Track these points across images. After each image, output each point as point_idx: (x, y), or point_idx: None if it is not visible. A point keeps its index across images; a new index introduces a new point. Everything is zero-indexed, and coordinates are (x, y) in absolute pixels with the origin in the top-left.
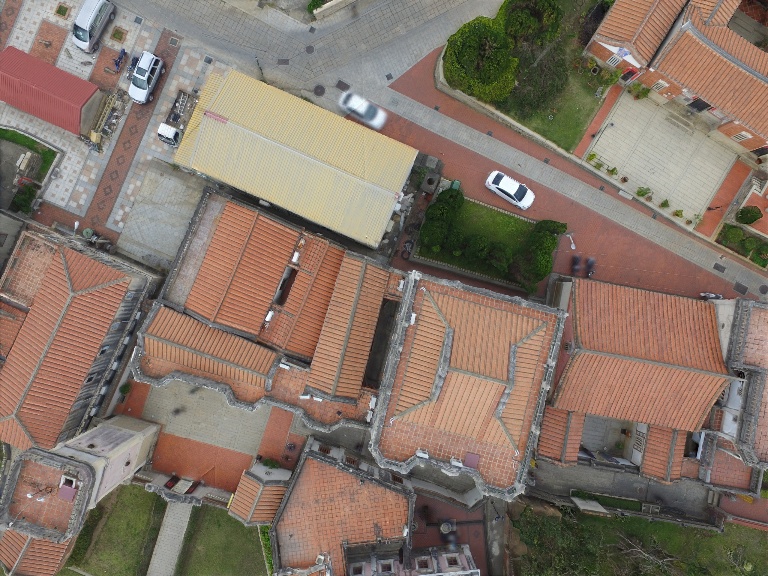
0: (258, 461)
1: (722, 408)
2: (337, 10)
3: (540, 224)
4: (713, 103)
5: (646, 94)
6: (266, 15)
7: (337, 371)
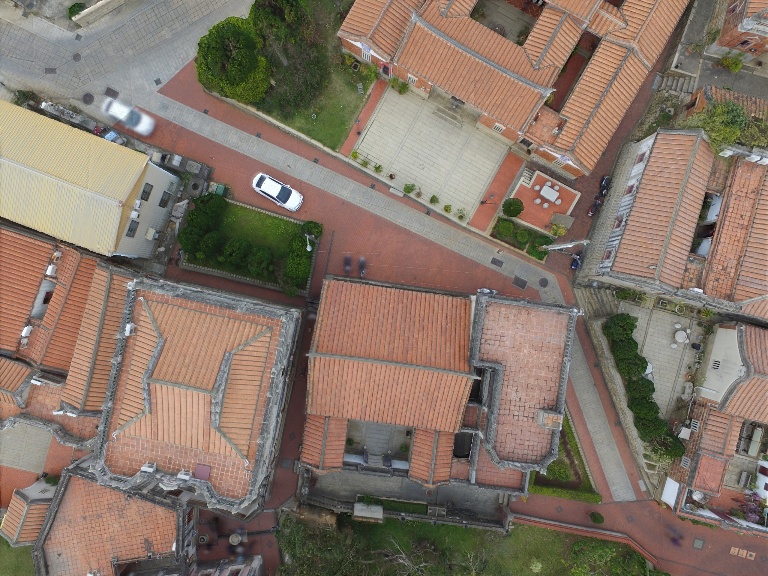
0: (42, 479)
1: (482, 407)
2: (101, 16)
3: (302, 226)
4: (457, 95)
5: (405, 89)
6: (31, 24)
7: (86, 385)
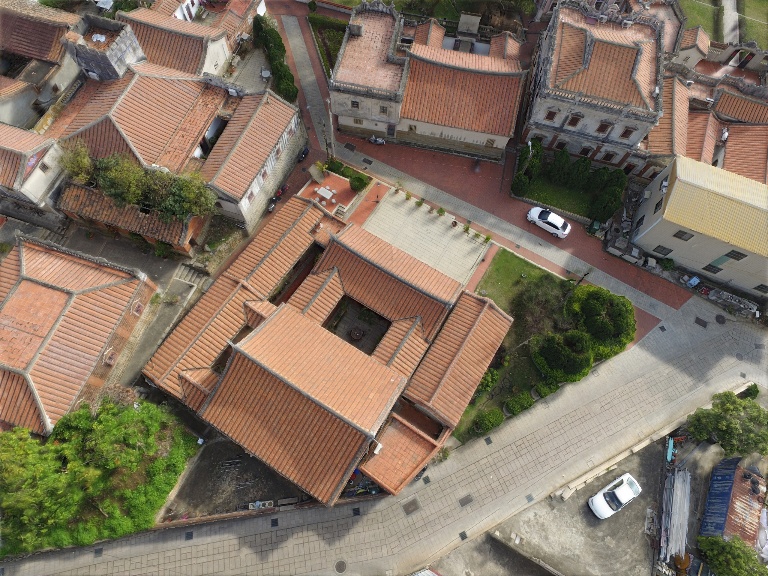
0: None
1: None
2: None
3: None
4: (407, 254)
5: None
6: None
7: None
